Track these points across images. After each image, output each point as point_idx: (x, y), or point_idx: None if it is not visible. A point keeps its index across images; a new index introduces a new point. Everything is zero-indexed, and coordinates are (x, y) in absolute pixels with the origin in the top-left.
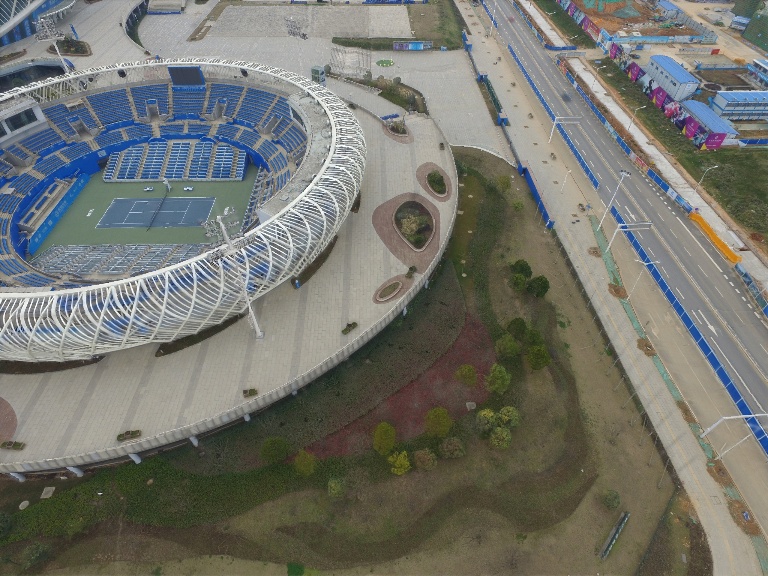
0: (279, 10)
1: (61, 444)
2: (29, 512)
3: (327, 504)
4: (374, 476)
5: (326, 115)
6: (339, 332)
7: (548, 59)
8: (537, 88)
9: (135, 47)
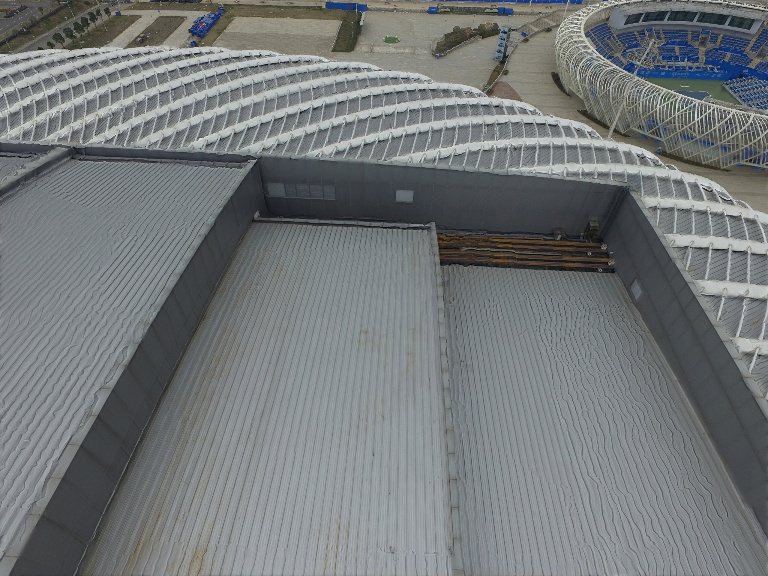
0: None
1: None
2: None
3: None
4: None
5: (646, 2)
6: None
7: None
8: None
9: None
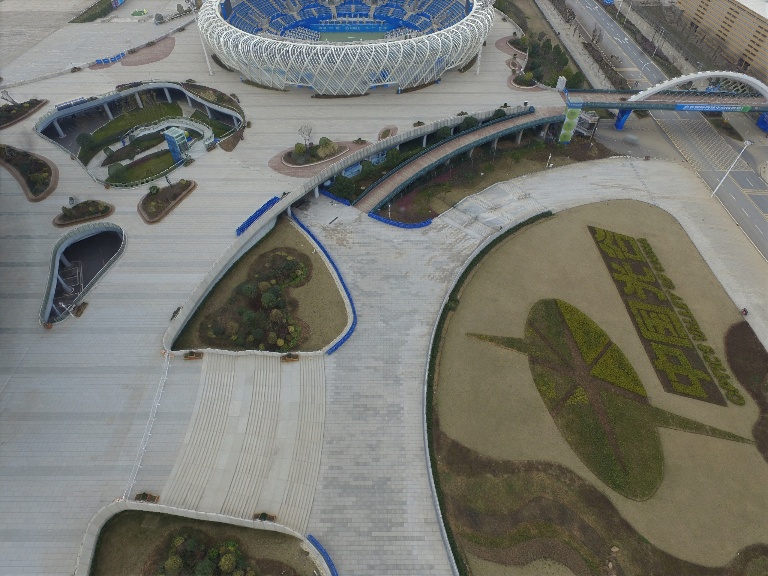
0: None
1: None
2: None
3: None
4: None
5: None
6: None
7: None
8: None
9: (43, 80)
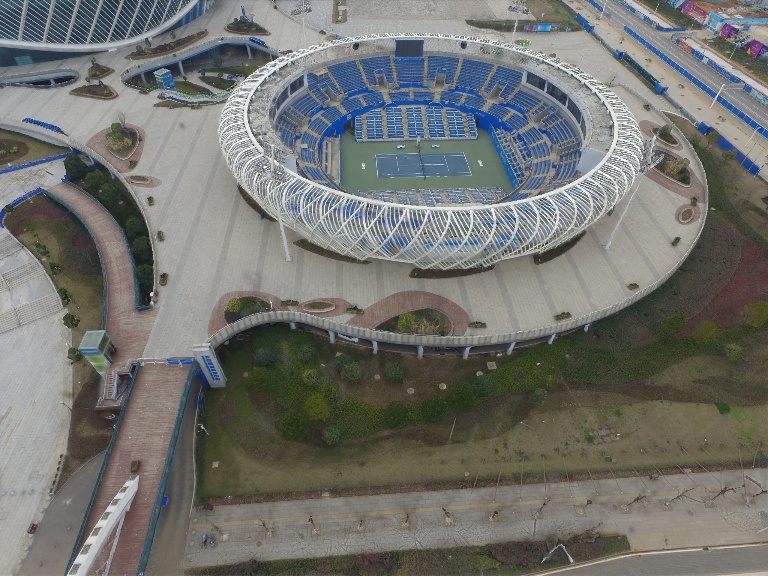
0: None
1: (513, 323)
2: (490, 378)
3: (721, 364)
4: (748, 344)
5: (572, 78)
6: (669, 244)
7: (664, 39)
8: (676, 63)
9: (305, 27)
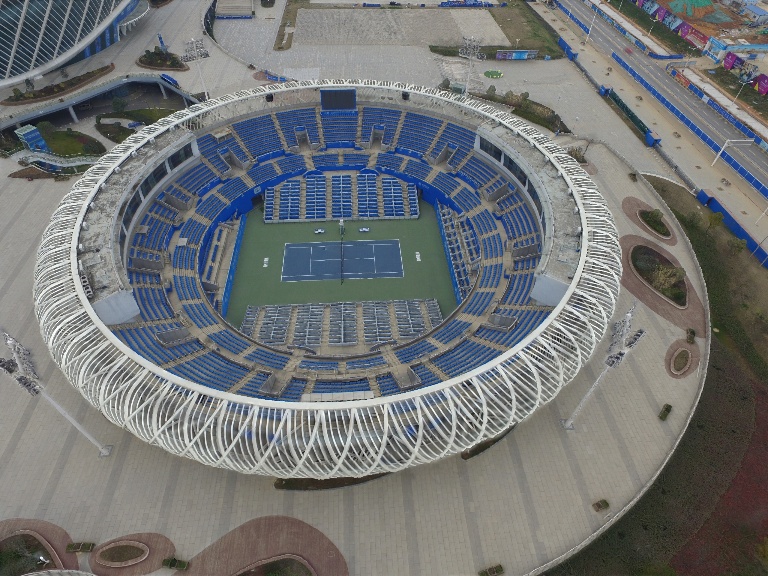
0: (357, 14)
1: None
2: None
3: None
4: None
5: (535, 149)
6: (655, 418)
7: (658, 69)
8: (671, 103)
9: (233, 60)
